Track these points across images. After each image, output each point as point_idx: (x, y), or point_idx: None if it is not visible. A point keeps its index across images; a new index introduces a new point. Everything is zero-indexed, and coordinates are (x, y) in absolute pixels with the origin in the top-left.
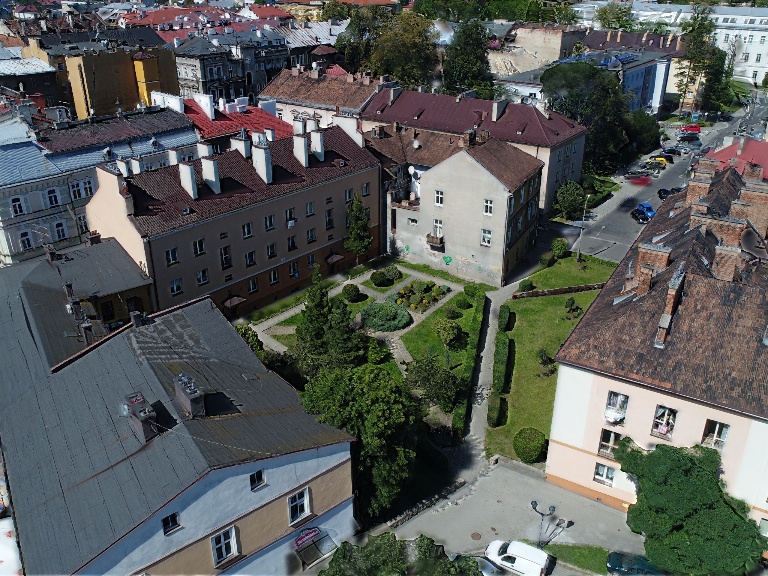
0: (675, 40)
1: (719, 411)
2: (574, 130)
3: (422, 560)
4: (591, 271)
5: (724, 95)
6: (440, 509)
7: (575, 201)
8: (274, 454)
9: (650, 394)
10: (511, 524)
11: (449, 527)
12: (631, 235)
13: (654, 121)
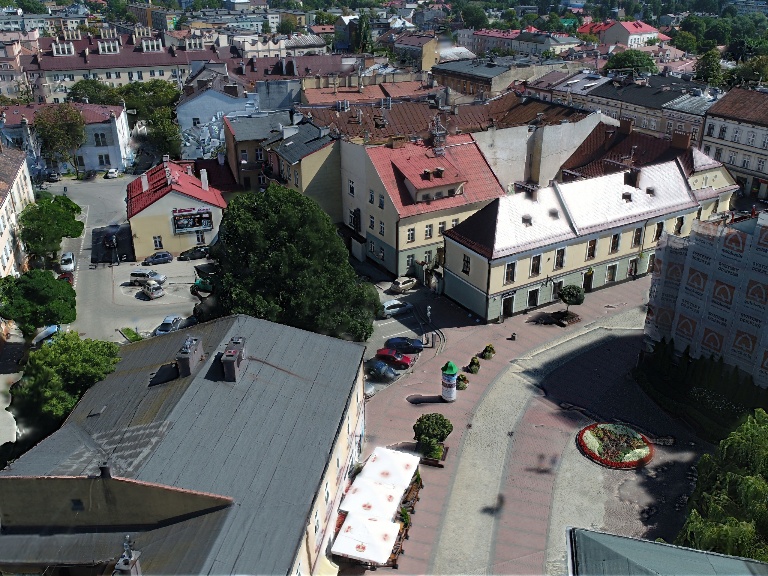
0: None
1: None
2: None
3: None
4: None
5: None
6: None
7: None
8: None
9: None
10: None
11: None
12: None
13: None
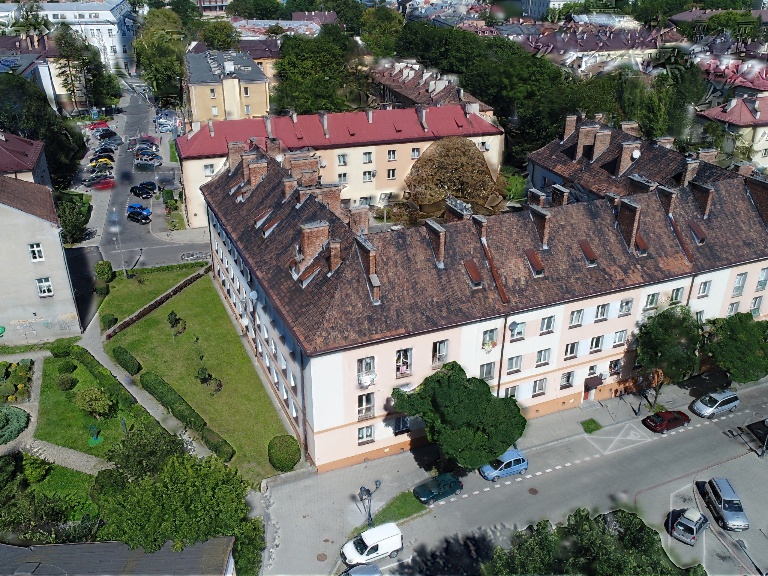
0: (42, 40)
1: (440, 332)
2: (36, 147)
3: (558, 541)
4: (150, 282)
5: (111, 88)
6: (270, 561)
7: (77, 221)
8: None
9: (390, 345)
10: (333, 526)
11: (295, 569)
12: (147, 237)
13: (75, 124)
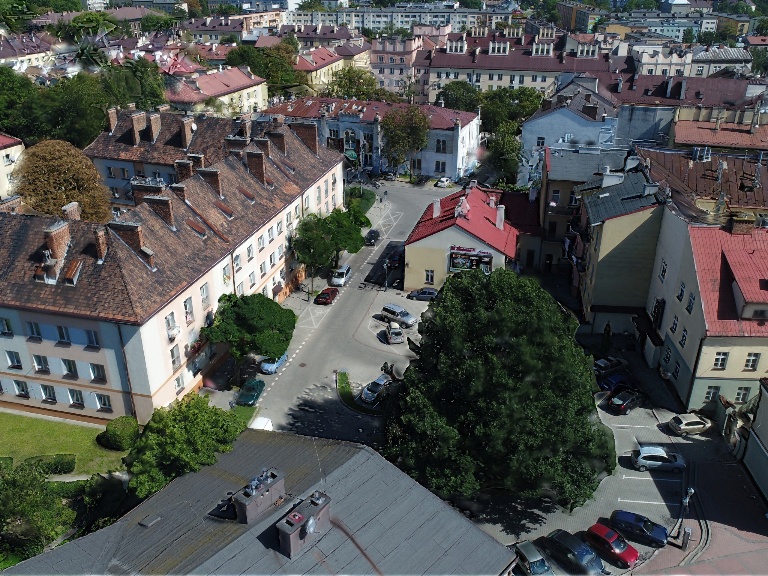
0: None
1: None
2: None
3: (456, 291)
4: None
5: None
6: None
7: None
8: (314, 439)
9: (180, 298)
10: None
11: None
12: None
13: None
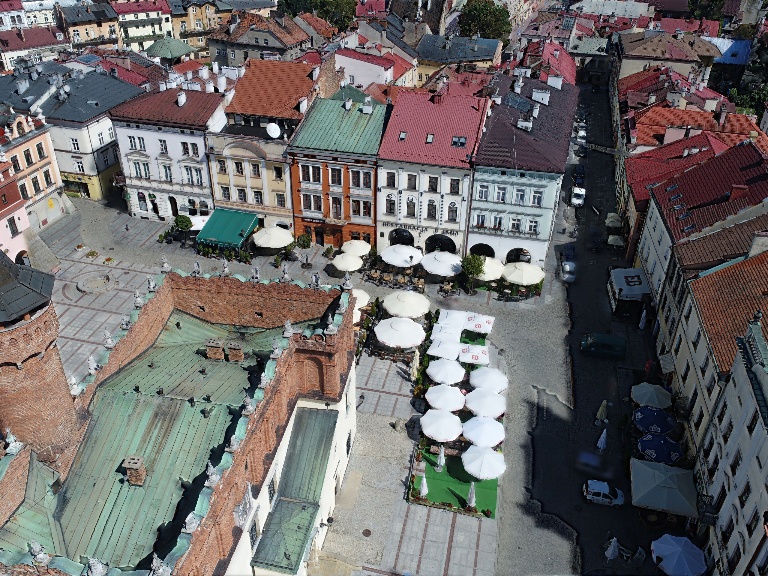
0: None
1: None
2: None
3: None
4: None
5: None
6: None
7: None
8: None
9: None
10: None
11: None
12: None
13: None
